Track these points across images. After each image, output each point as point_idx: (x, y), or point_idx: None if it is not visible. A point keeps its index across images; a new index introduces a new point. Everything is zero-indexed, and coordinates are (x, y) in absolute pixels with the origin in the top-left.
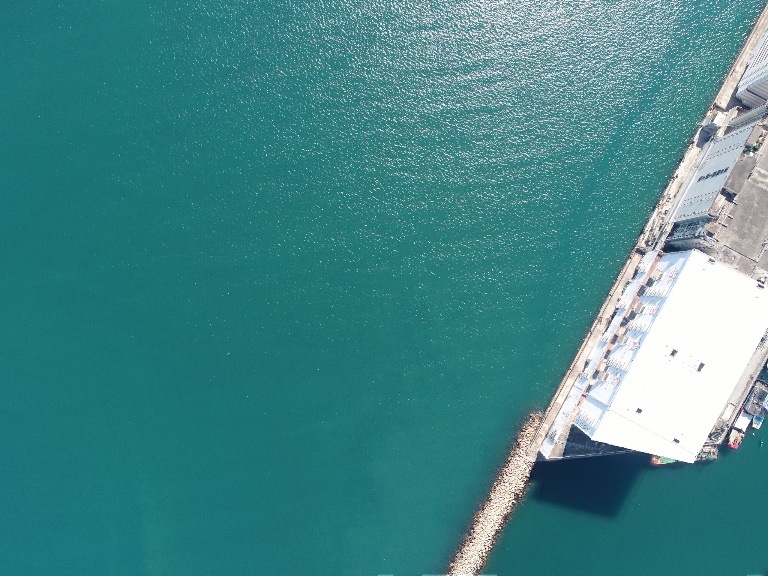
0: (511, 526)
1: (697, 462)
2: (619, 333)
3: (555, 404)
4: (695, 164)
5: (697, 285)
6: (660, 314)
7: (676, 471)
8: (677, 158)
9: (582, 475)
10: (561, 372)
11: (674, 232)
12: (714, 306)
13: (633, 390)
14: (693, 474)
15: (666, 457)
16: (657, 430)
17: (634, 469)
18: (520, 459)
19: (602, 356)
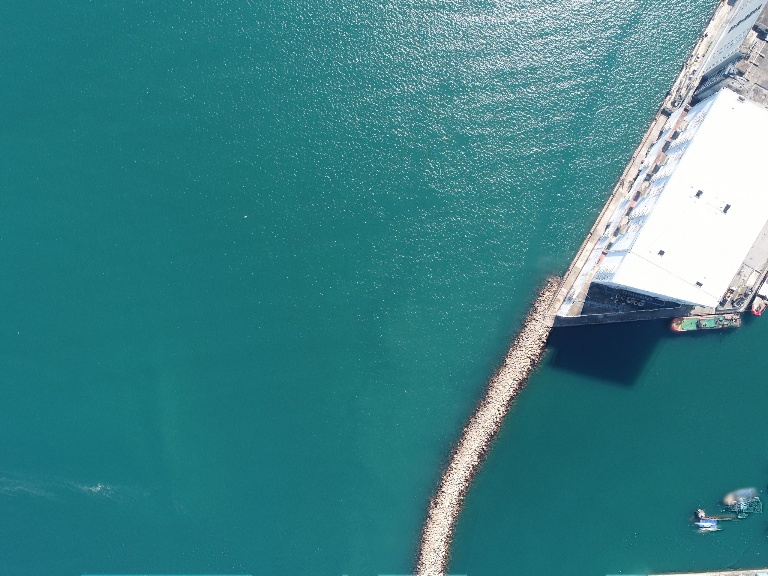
0: (526, 393)
1: (718, 331)
2: (642, 187)
3: (574, 268)
4: (726, 21)
5: (725, 124)
6: (686, 154)
7: (696, 340)
8: (707, 16)
9: (600, 341)
10: (581, 236)
11: (702, 86)
12: (742, 145)
13: (656, 232)
14: (714, 343)
15: (688, 301)
16: (679, 273)
17: (653, 336)
18: (537, 323)
19: (624, 213)
